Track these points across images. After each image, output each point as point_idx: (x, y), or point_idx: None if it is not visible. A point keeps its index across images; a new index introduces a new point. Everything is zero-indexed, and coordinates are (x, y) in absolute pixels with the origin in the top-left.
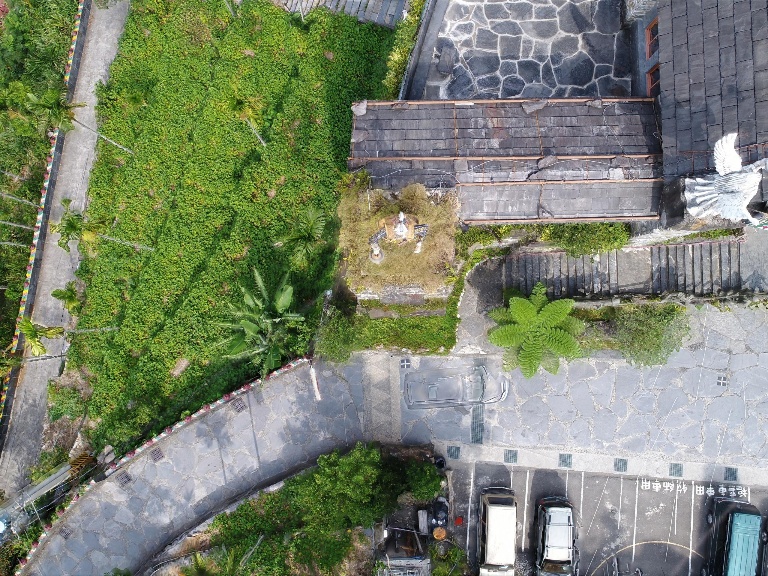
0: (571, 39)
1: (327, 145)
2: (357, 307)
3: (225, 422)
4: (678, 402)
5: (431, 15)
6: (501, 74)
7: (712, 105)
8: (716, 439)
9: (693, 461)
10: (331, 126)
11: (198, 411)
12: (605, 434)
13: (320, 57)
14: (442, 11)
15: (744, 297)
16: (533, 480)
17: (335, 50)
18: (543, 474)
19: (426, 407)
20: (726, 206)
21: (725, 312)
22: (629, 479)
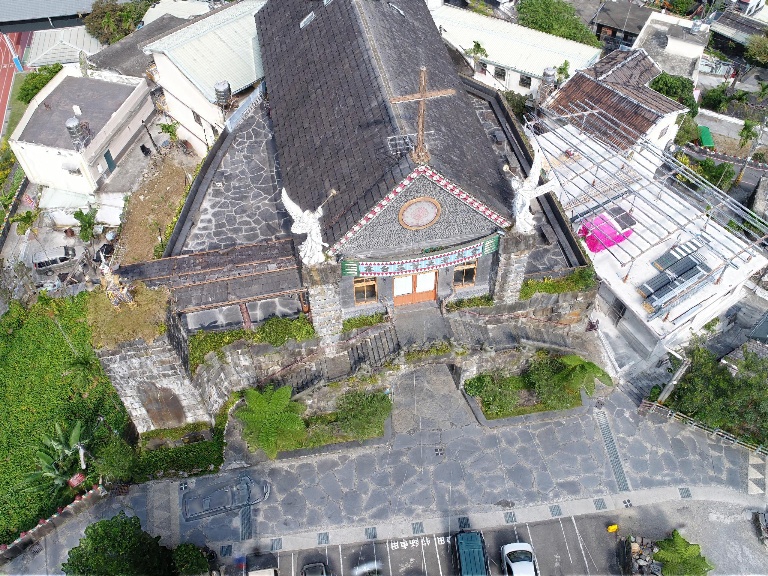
0: (268, 239)
1: None
2: (139, 440)
3: (22, 567)
4: (408, 474)
5: (177, 238)
6: None
7: None
8: (445, 496)
9: (430, 518)
10: None
11: None
12: (354, 510)
13: None
14: (184, 235)
15: (399, 351)
16: (297, 561)
17: None
18: (306, 554)
19: (201, 517)
20: None
21: (429, 403)
22: (380, 543)
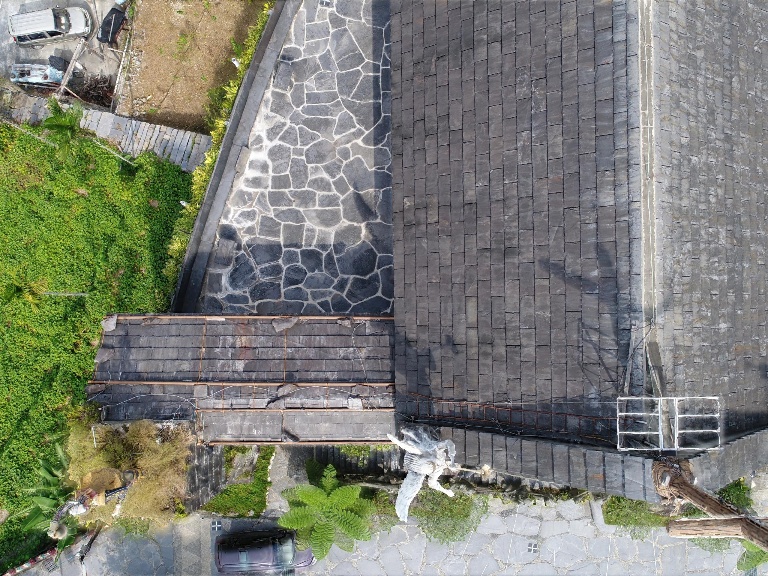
0: (354, 228)
1: (150, 295)
2: None
3: None
4: (488, 568)
5: (211, 204)
6: (283, 263)
7: (433, 352)
8: None
9: None
10: (154, 277)
11: (4, 574)
12: None
13: (144, 206)
14: (222, 200)
15: (519, 497)
16: None
17: (159, 199)
18: None
19: (236, 570)
20: (401, 495)
21: None
22: None
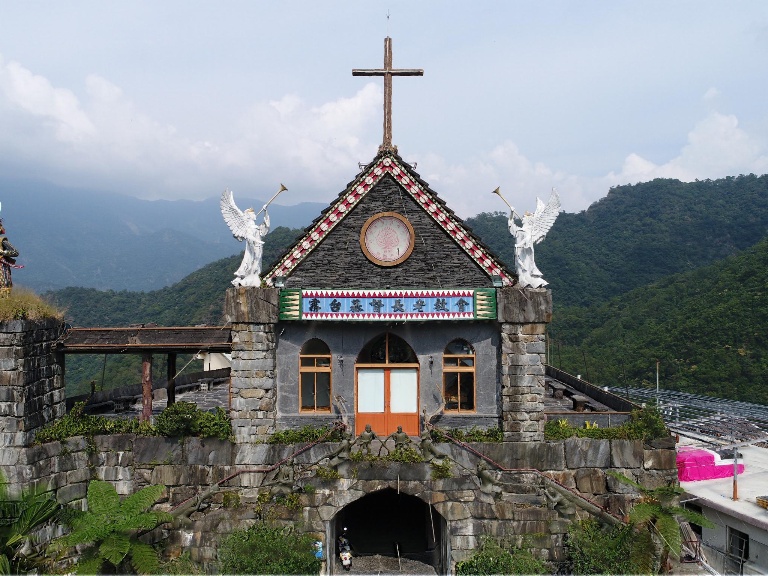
0: None
1: None
2: None
3: None
4: None
5: None
6: None
7: None
8: None
9: None
10: None
11: None
12: None
13: None
14: None
15: None
16: None
17: None
18: None
19: None
20: None
21: None
22: None
